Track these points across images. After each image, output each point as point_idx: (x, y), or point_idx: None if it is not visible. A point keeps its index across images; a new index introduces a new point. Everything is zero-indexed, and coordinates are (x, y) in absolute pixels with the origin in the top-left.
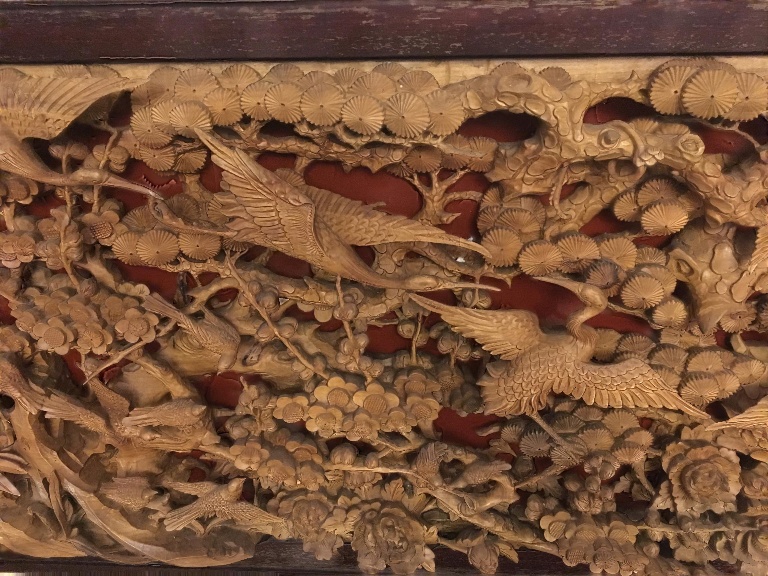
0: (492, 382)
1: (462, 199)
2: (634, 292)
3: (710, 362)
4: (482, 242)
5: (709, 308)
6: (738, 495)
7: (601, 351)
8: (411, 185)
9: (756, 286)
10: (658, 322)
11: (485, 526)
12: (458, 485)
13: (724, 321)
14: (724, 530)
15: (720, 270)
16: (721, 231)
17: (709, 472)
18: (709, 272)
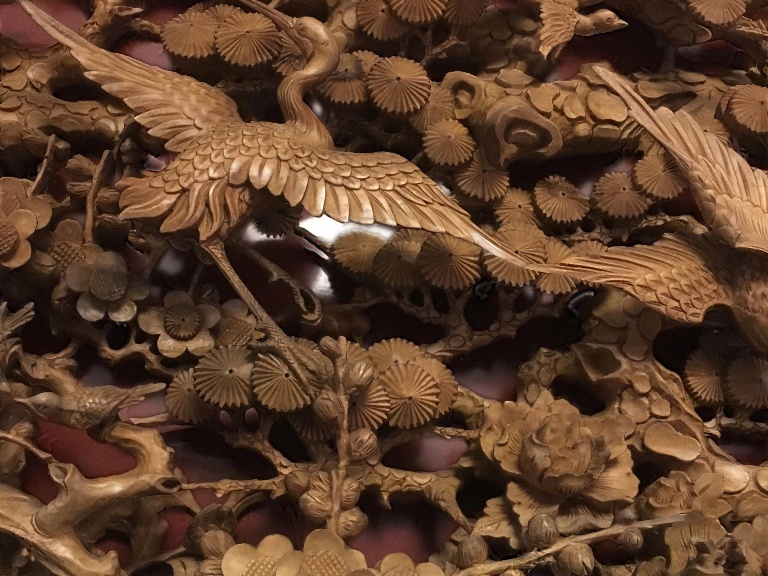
0: (144, 178)
1: (153, 33)
2: (384, 73)
3: (527, 231)
4: (165, 25)
5: (498, 105)
6: (648, 549)
7: (358, 255)
8: (82, 5)
9: (564, 107)
10: (433, 155)
11: (88, 571)
12: (37, 396)
13: (541, 199)
14: (617, 531)
15: (509, 81)
16: (507, 66)
17: (566, 429)
18: (495, 86)
